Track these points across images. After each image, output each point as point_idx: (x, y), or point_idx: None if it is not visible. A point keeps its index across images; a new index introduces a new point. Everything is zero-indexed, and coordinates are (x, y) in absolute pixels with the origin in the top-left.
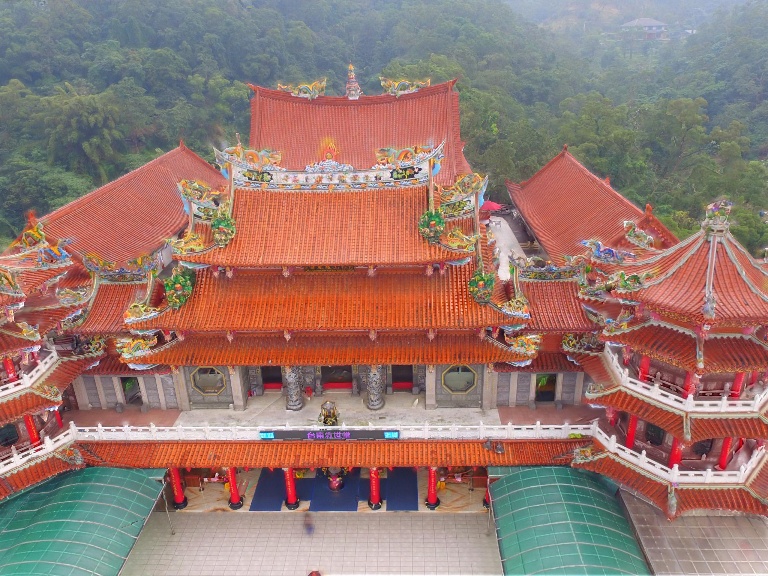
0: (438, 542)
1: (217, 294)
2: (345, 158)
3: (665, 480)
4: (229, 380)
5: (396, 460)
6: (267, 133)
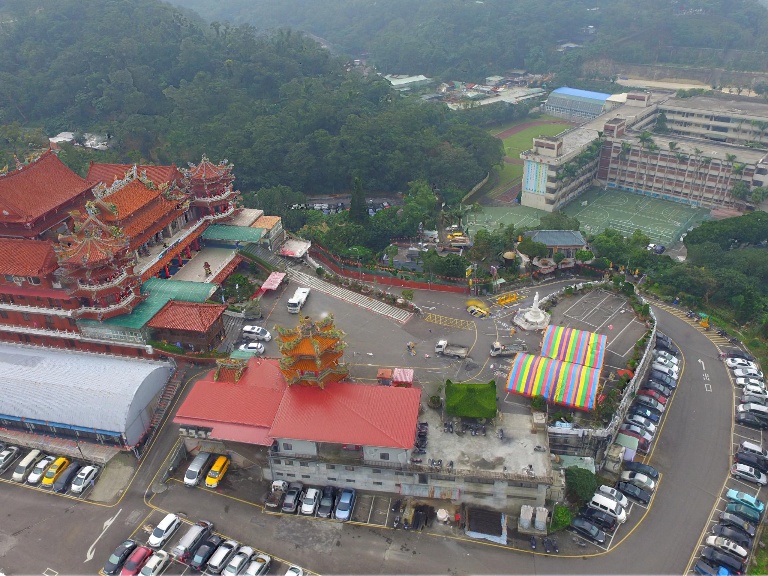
0: (202, 259)
1: (122, 230)
2: (46, 193)
3: (226, 216)
4: None
5: (186, 244)
6: (5, 196)
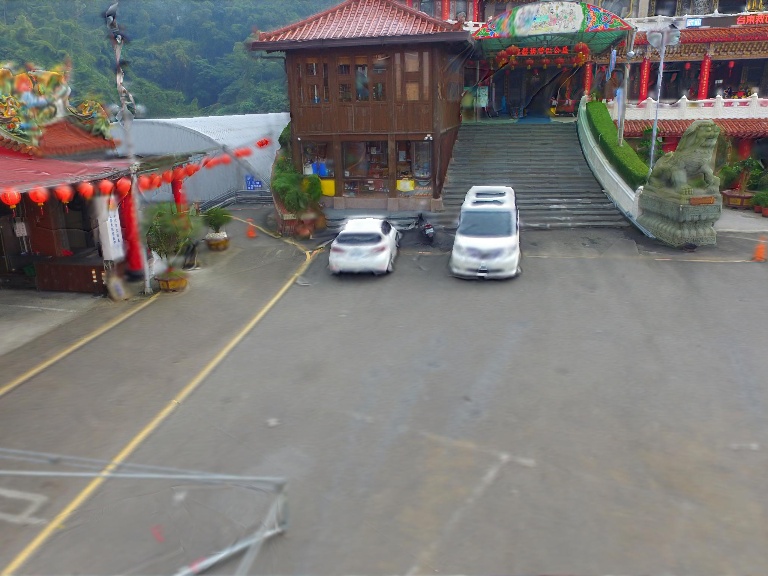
0: None
1: None
2: None
3: None
4: (636, 5)
5: None
6: None
